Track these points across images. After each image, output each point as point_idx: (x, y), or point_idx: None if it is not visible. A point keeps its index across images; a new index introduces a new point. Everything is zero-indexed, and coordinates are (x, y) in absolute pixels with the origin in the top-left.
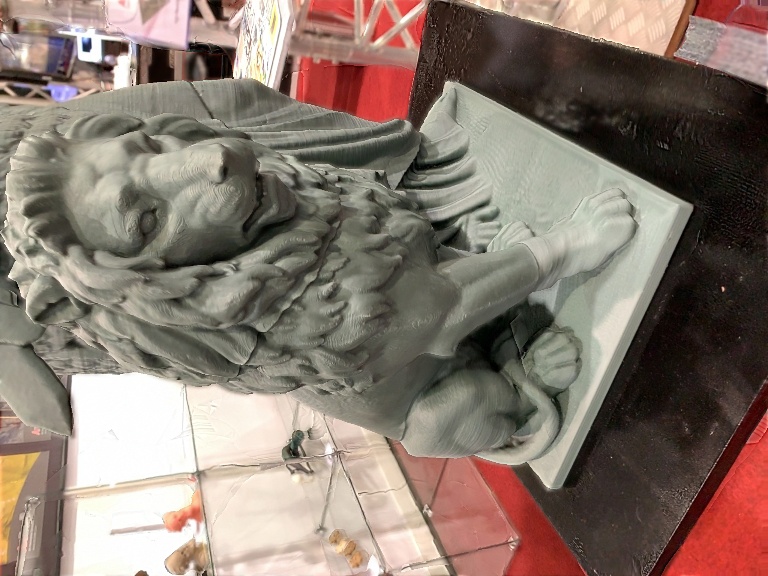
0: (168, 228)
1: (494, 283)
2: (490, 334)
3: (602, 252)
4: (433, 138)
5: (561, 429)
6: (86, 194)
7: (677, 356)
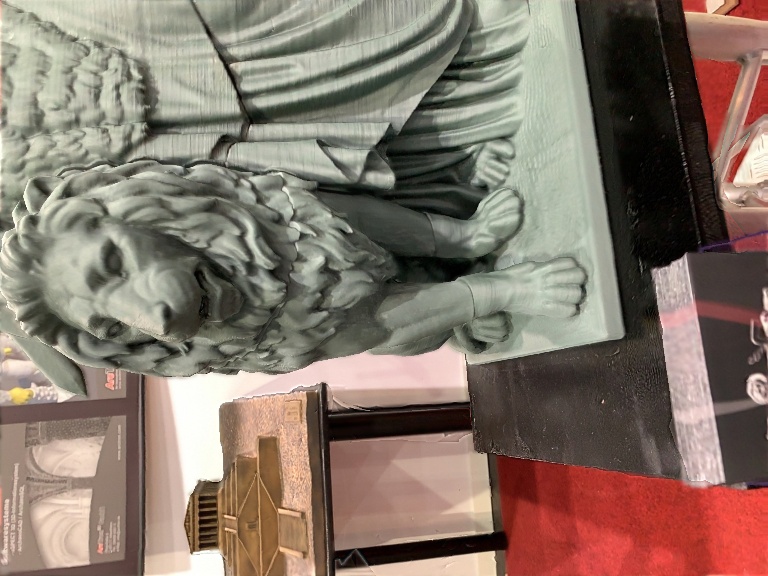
0: (131, 332)
1: (424, 329)
2: (457, 268)
3: (540, 314)
4: (487, 21)
5: (484, 351)
6: (63, 306)
7: (562, 394)
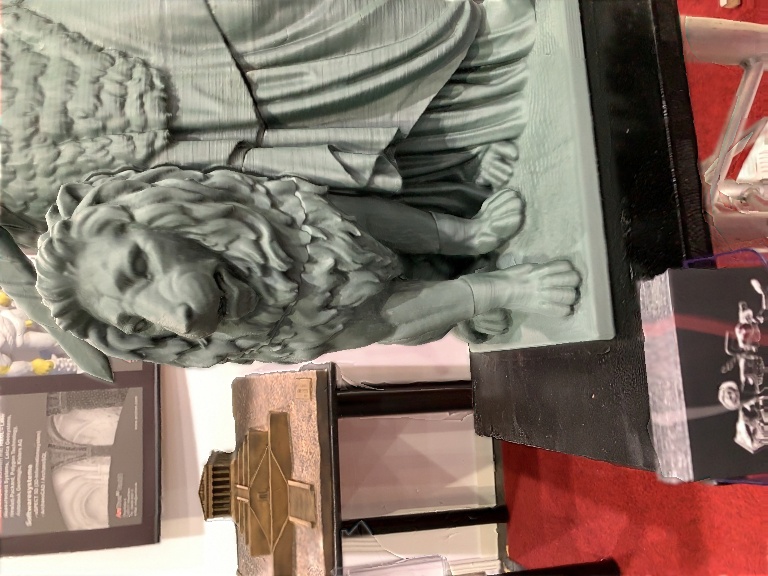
0: (155, 328)
1: (427, 325)
2: (461, 262)
3: None
4: (495, 27)
5: None
6: (94, 304)
7: (557, 386)
